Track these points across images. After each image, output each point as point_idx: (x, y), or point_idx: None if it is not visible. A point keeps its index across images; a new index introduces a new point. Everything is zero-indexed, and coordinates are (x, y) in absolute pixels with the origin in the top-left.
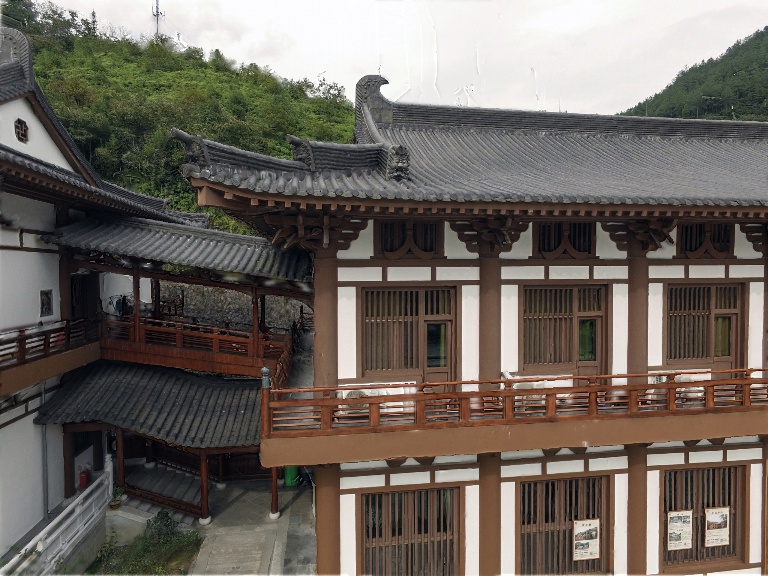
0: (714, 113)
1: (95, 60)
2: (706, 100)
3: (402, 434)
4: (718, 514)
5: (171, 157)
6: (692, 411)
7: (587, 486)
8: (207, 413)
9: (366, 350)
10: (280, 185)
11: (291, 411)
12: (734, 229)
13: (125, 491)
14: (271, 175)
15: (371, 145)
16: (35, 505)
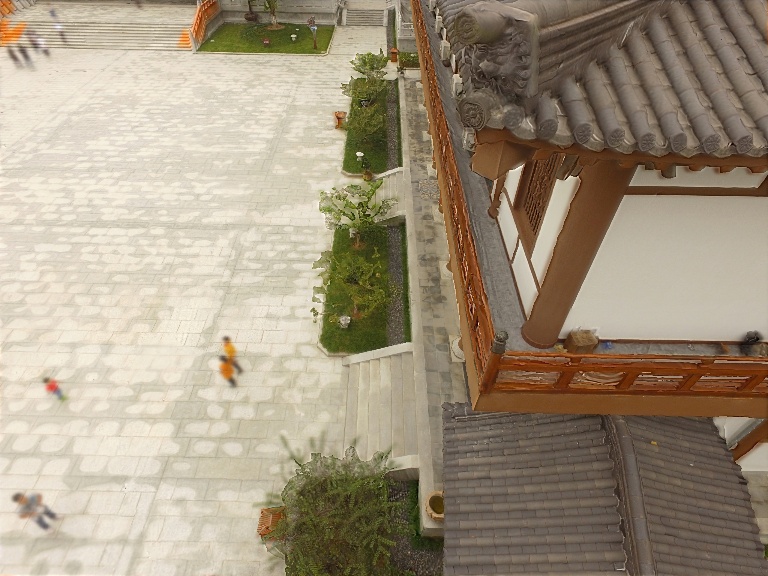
0: None
1: None
2: None
3: (411, 1)
4: None
5: None
6: None
7: None
8: None
9: None
10: None
11: None
12: None
13: None
14: None
15: None
16: None
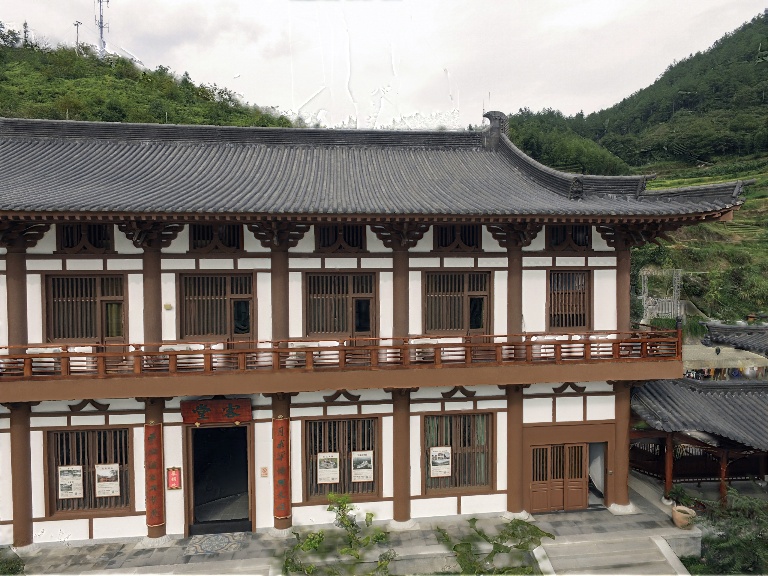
0: (690, 108)
1: None
2: (682, 95)
3: None
4: (108, 469)
5: None
6: (8, 379)
7: None
8: None
9: None
10: None
11: None
12: (113, 229)
13: None
14: None
15: None
16: None
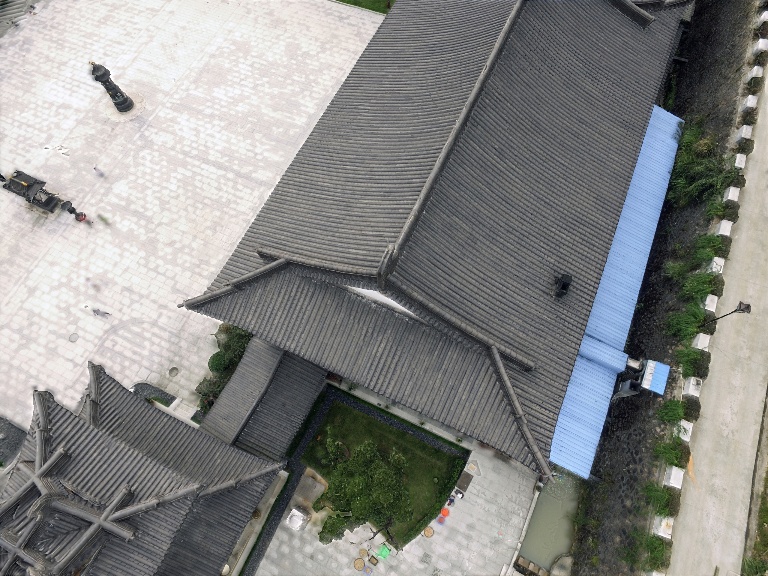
0: None
1: None
2: None
3: None
4: None
5: None
6: None
7: None
8: None
9: None
10: None
11: None
12: None
13: None
14: None
15: None
16: None
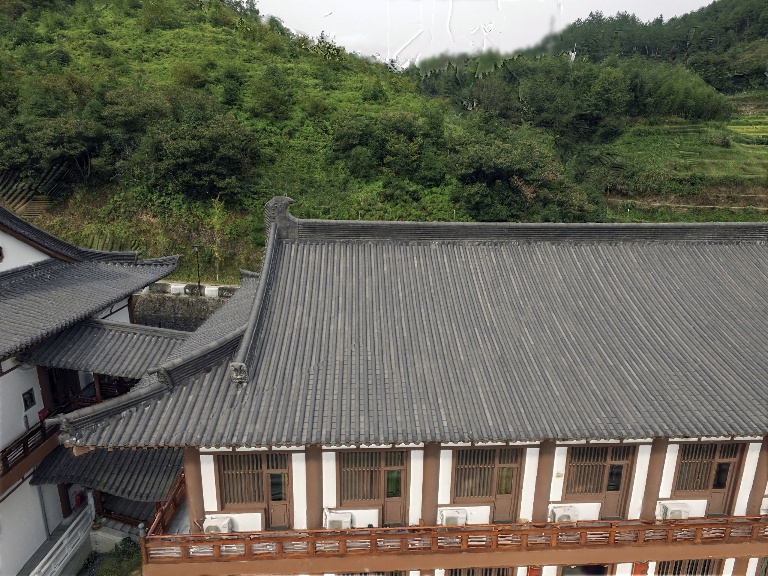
0: None
1: (95, 22)
2: None
3: (236, 563)
4: None
5: (158, 166)
6: (449, 551)
7: (391, 575)
8: (157, 468)
9: (225, 491)
10: (125, 440)
11: (161, 548)
12: None
13: (104, 515)
14: (131, 410)
15: (234, 333)
16: (39, 533)
